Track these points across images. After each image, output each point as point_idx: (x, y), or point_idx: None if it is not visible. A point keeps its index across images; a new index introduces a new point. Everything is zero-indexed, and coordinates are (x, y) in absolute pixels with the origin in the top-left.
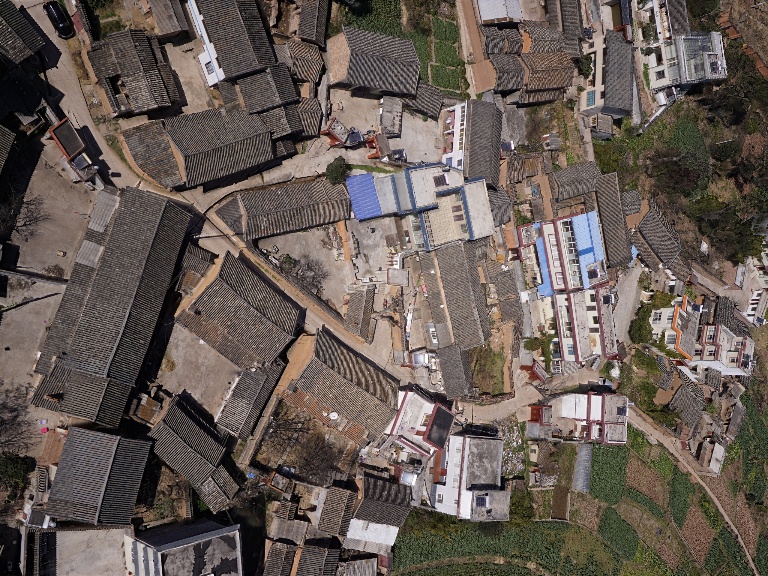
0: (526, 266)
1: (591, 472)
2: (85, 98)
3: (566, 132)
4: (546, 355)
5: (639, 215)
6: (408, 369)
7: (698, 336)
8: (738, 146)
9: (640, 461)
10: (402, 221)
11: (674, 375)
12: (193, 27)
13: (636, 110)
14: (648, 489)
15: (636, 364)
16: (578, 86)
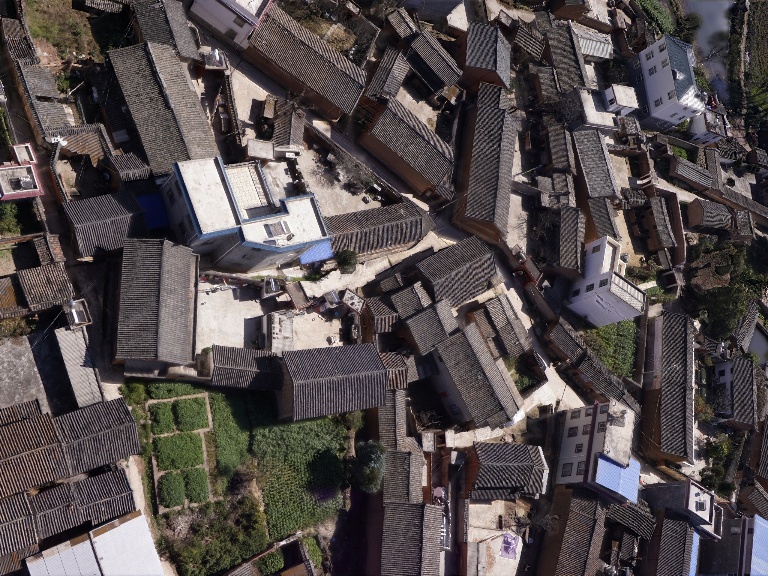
0: None
1: None
2: None
3: None
4: None
5: None
6: None
7: None
8: None
9: None
10: None
11: None
12: None
13: None
14: None
15: None
16: None
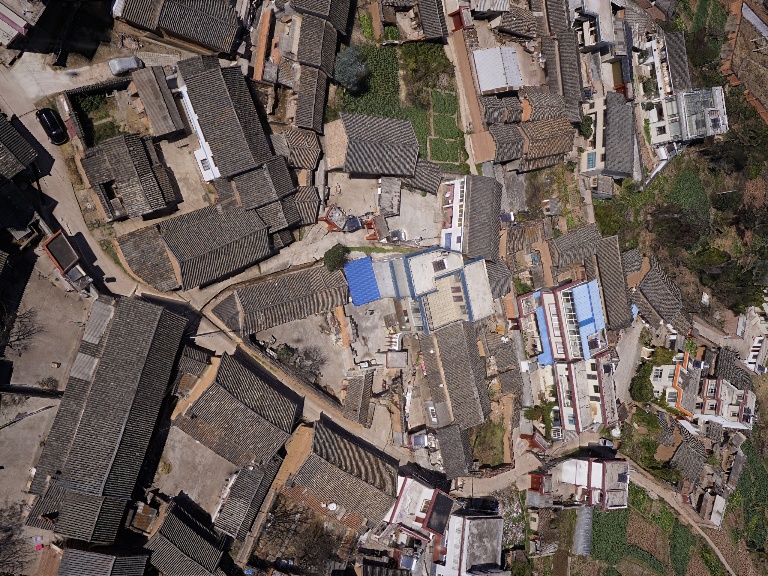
0: (526, 334)
1: (592, 534)
2: (79, 203)
3: (566, 196)
4: (546, 422)
5: (640, 273)
6: (407, 449)
7: (699, 389)
8: (739, 197)
9: (641, 517)
10: (401, 301)
11: (675, 431)
12: (188, 122)
13: (637, 167)
14: (649, 545)
15: (637, 421)
16: (578, 147)
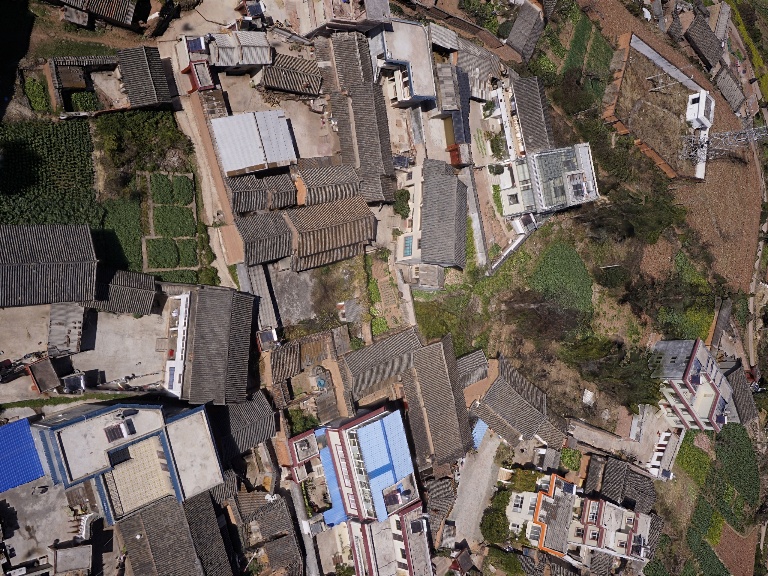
0: (313, 480)
1: None
2: None
3: None
4: None
5: (486, 381)
6: None
7: (580, 511)
8: (625, 273)
9: None
10: None
11: (545, 570)
12: None
13: (480, 247)
14: None
15: (494, 562)
16: (394, 229)
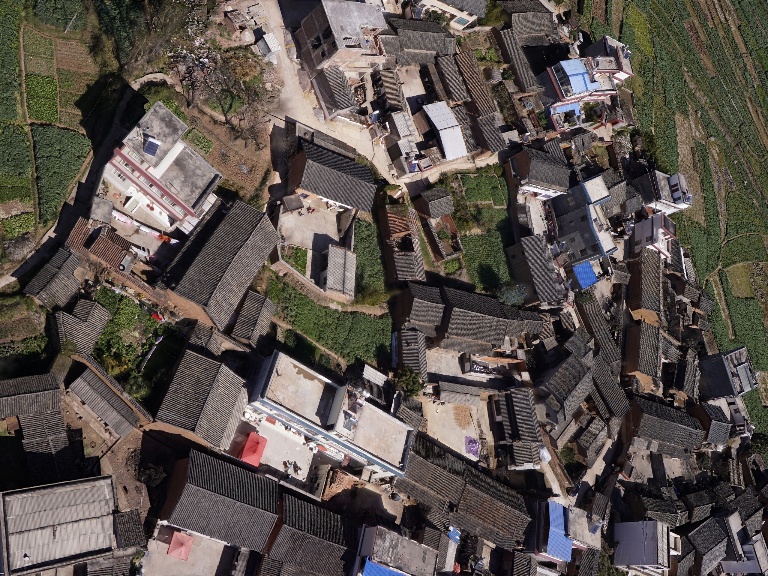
0: None
1: None
2: None
3: None
4: None
5: None
6: None
7: None
8: None
9: None
10: None
11: None
12: None
13: None
14: None
15: None
16: None
